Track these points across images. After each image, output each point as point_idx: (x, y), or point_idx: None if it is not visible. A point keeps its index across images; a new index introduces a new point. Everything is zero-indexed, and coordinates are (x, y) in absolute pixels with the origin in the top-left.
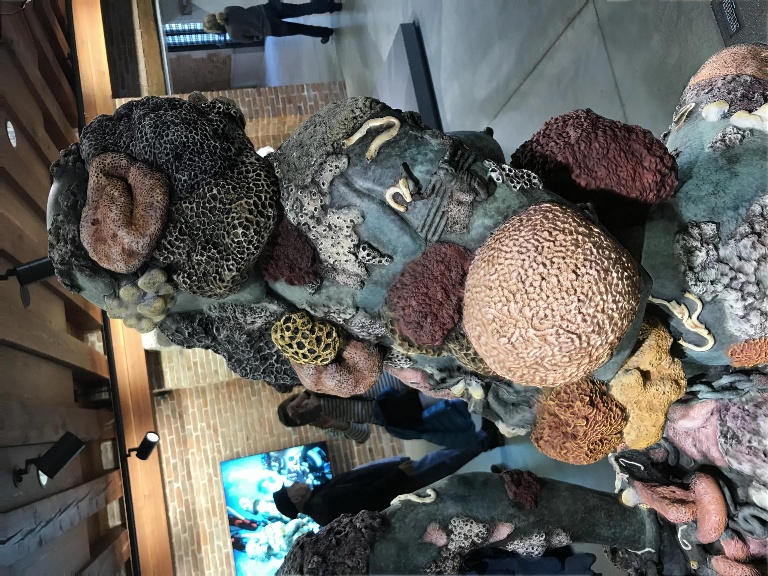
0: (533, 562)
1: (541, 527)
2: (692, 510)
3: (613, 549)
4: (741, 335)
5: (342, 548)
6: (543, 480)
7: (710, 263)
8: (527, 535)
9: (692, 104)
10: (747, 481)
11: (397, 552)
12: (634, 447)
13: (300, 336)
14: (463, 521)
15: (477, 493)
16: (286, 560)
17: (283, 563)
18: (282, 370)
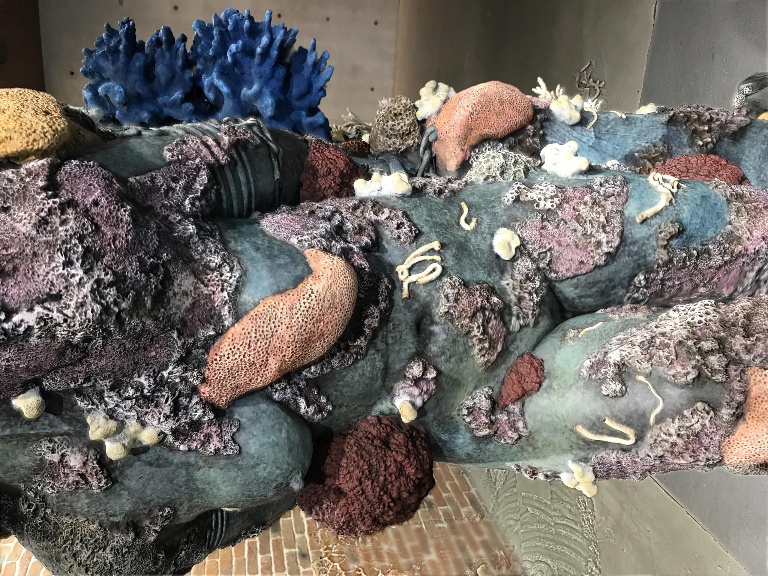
0: None
1: None
2: None
3: None
4: None
5: None
6: None
7: None
8: None
9: (629, 443)
10: None
11: None
12: None
13: None
14: None
15: None
16: None
17: None
18: None
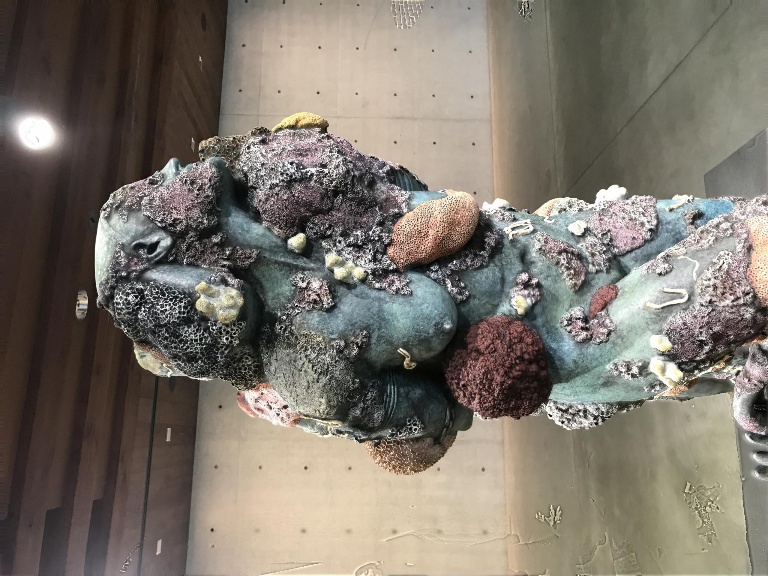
0: None
1: None
2: None
3: None
4: None
5: None
6: None
7: None
8: None
9: (684, 299)
10: None
11: None
12: None
13: None
14: None
15: None
16: None
17: None
18: None
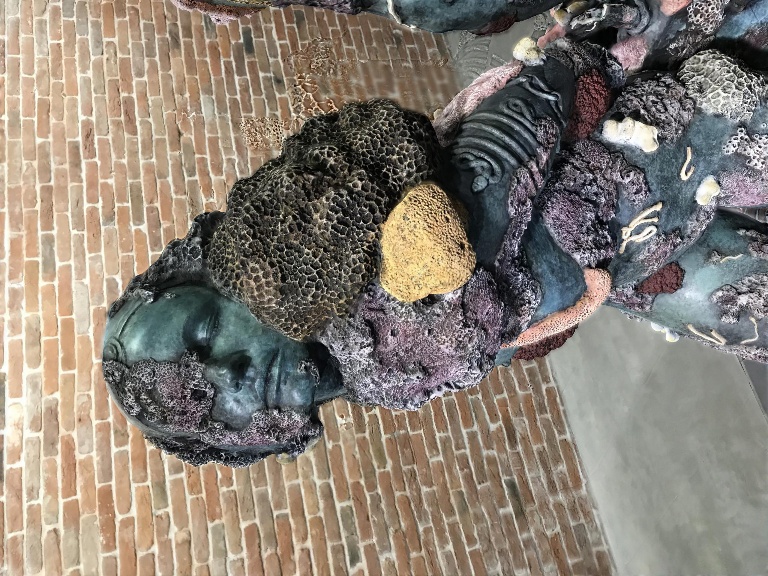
0: None
1: None
2: None
3: None
4: None
5: None
6: None
7: None
8: None
9: None
10: None
11: None
12: None
13: None
14: None
15: None
16: None
17: None
18: None
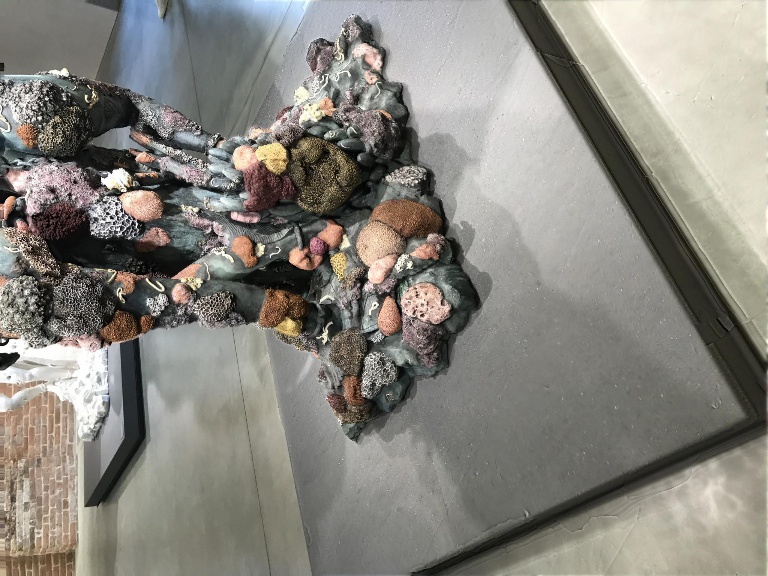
0: None
1: None
2: (2, 204)
3: None
4: (19, 122)
5: None
6: None
7: (6, 92)
8: None
9: None
10: None
11: None
12: None
13: None
14: None
15: None
16: None
17: None
18: None
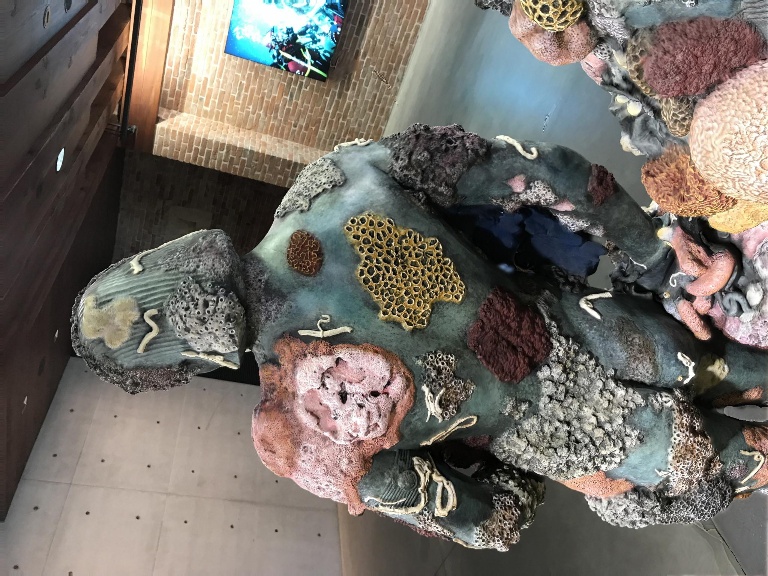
0: (565, 232)
1: (592, 219)
2: (702, 272)
3: (617, 247)
4: None
5: (448, 156)
6: (617, 187)
7: None
8: (578, 218)
9: None
10: (754, 278)
11: (484, 180)
12: (712, 225)
13: (552, 1)
14: (544, 186)
15: (567, 172)
16: (399, 138)
17: (394, 136)
18: (501, 1)
